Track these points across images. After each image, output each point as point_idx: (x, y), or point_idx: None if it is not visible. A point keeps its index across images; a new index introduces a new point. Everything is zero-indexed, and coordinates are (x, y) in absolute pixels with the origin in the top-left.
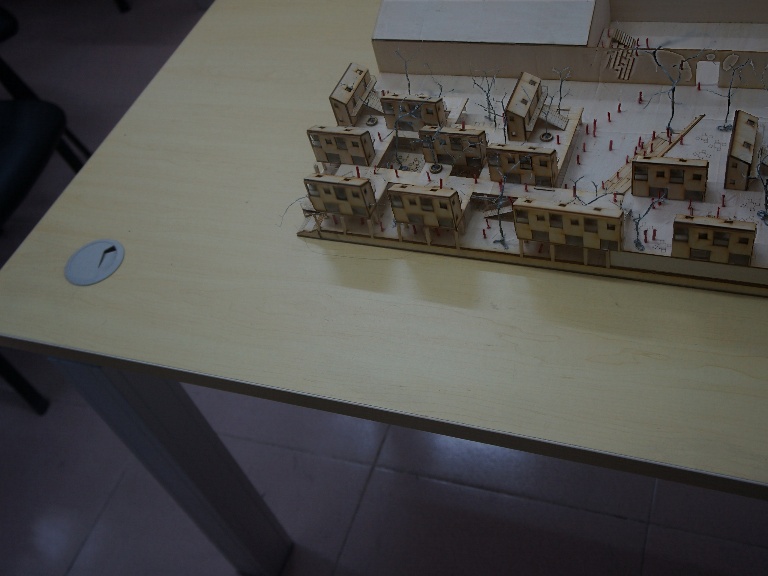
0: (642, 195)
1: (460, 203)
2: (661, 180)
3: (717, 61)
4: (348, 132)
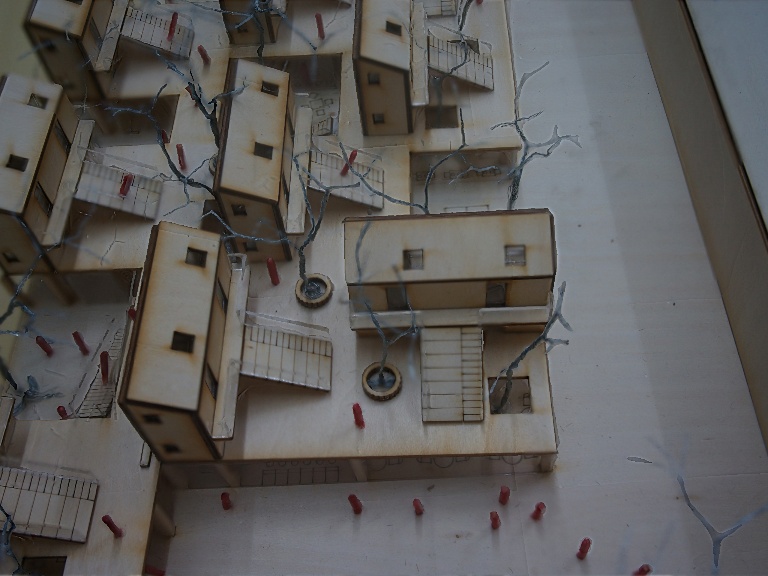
0: None
1: (42, 244)
2: None
3: None
4: None
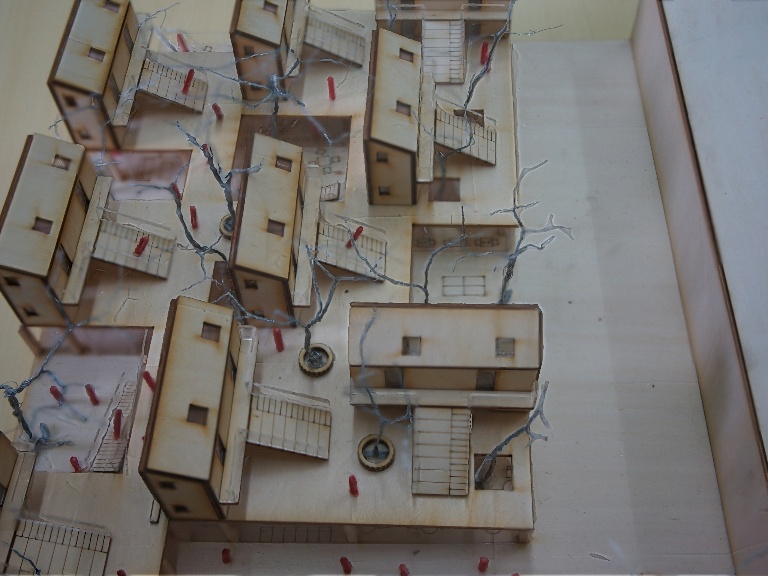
0: None
1: (62, 302)
2: None
3: None
4: (252, 7)
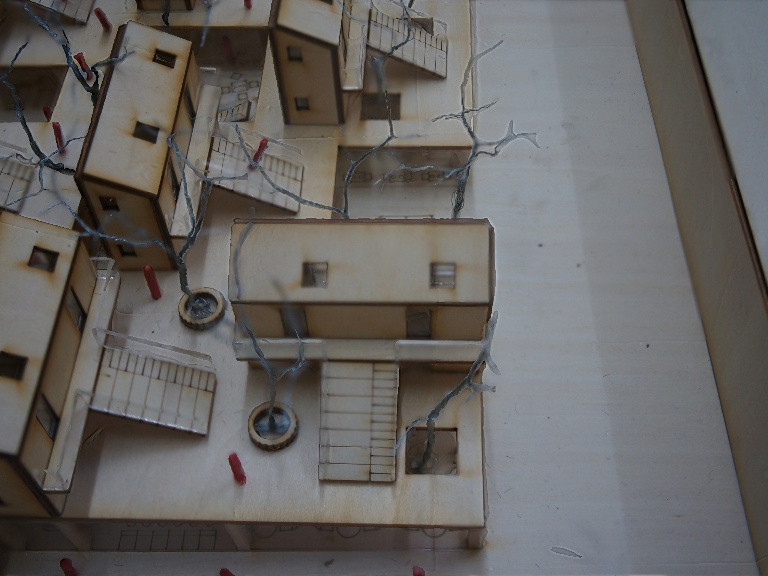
0: None
1: None
2: None
3: None
4: None
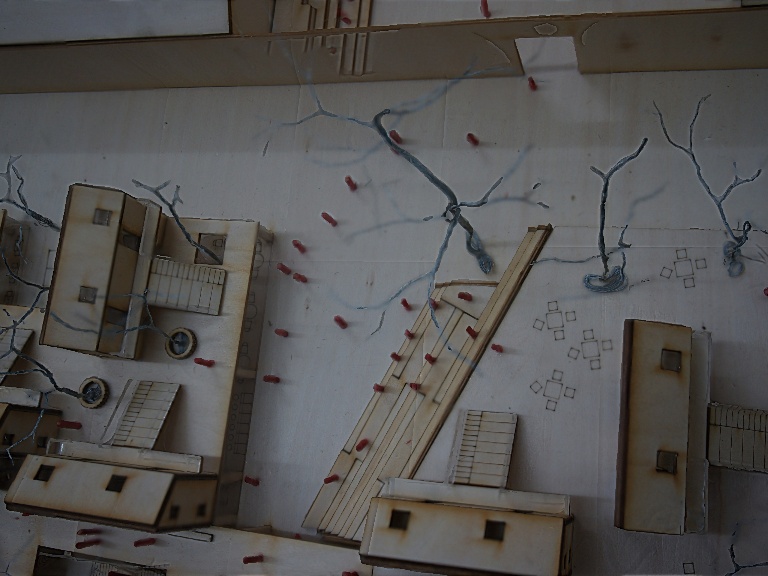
0: None
1: None
2: None
3: (564, 35)
4: None
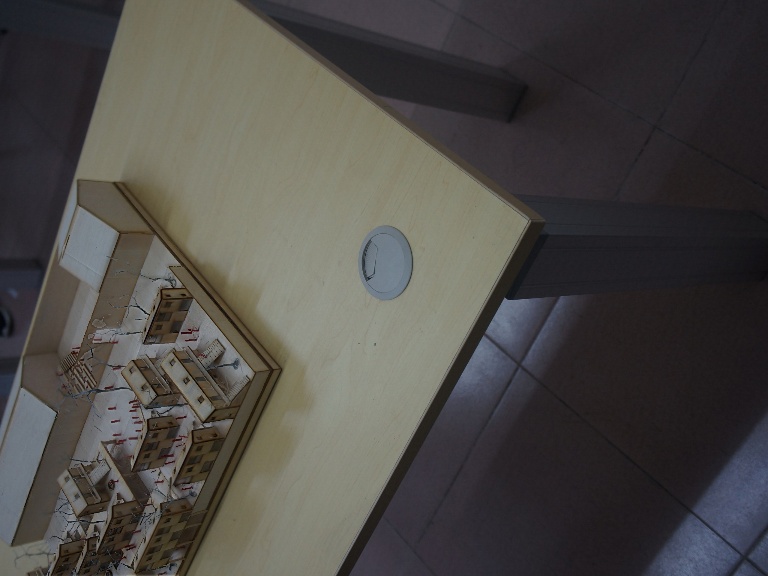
0: (164, 461)
1: None
2: (152, 454)
3: None
4: None
